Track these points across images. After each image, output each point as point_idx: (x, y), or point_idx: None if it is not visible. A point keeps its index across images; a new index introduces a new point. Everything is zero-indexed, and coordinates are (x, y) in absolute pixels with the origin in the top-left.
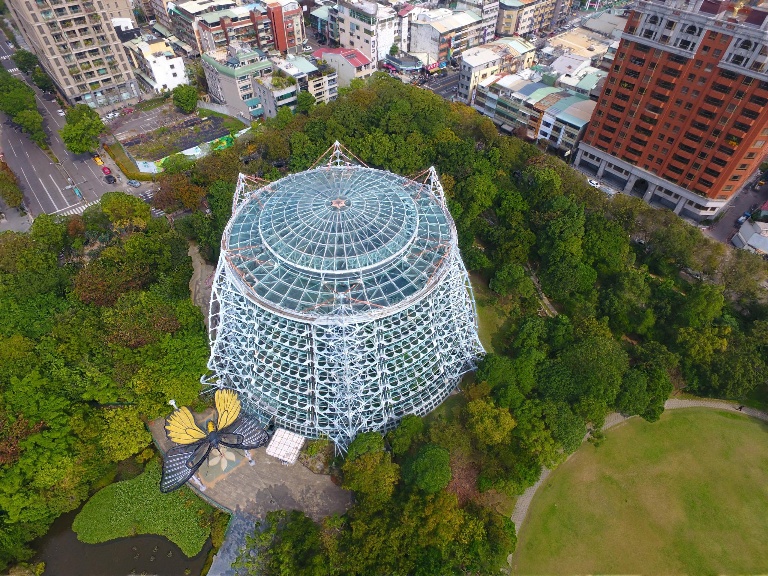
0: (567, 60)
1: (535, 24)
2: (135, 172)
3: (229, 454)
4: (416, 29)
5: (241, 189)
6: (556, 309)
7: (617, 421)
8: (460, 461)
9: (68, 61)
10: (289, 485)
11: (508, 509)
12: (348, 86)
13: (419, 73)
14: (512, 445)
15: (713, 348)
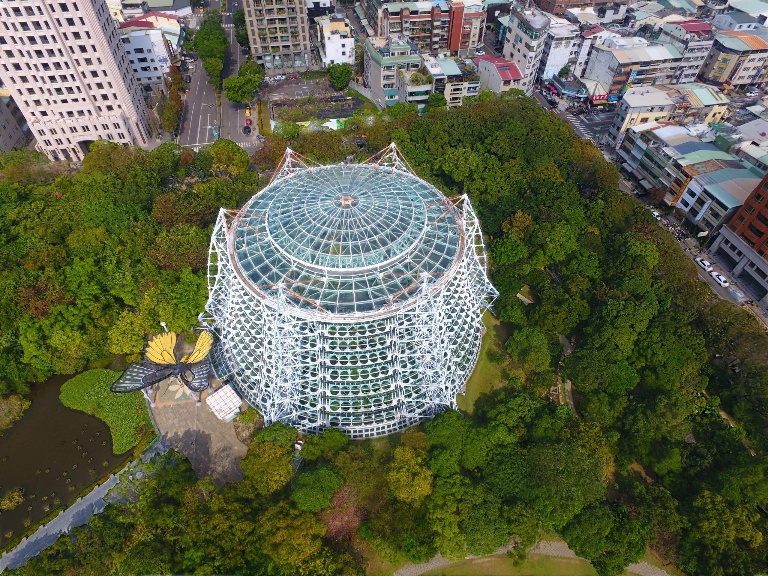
0: (765, 125)
1: (762, 76)
2: (268, 129)
3: (187, 388)
4: (596, 54)
5: (287, 163)
6: (574, 399)
7: (568, 554)
8: (356, 497)
9: (260, 24)
10: (213, 437)
11: (384, 572)
12: (478, 96)
13: (582, 102)
14: (418, 511)
15: (737, 535)
